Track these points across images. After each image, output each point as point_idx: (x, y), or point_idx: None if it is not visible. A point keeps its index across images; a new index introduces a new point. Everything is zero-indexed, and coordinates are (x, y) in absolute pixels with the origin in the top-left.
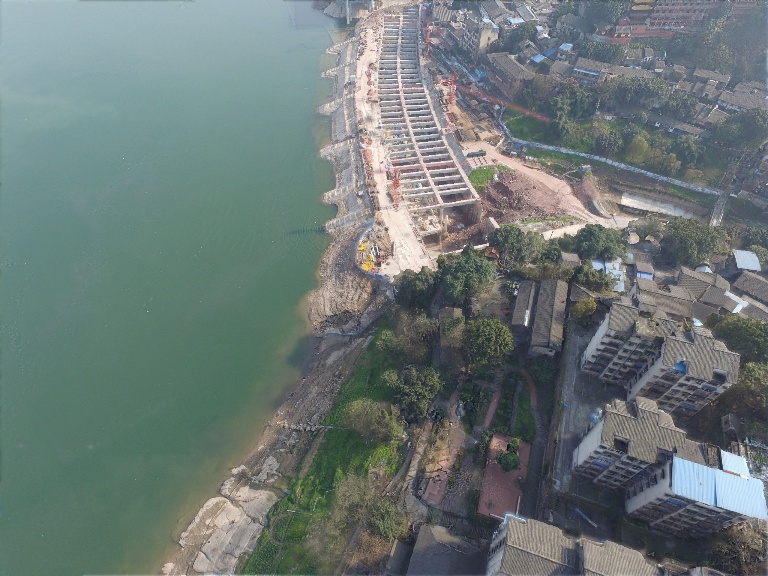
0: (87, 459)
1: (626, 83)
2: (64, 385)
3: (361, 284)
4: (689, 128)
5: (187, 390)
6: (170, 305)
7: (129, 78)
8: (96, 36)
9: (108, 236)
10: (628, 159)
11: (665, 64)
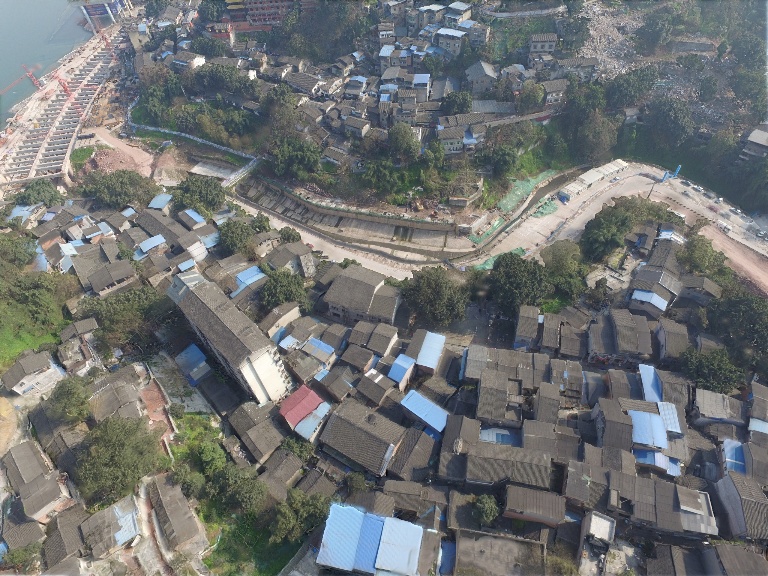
0: None
1: (202, 70)
2: None
3: None
4: (251, 105)
5: None
6: None
7: None
8: None
9: None
10: None
11: (266, 54)
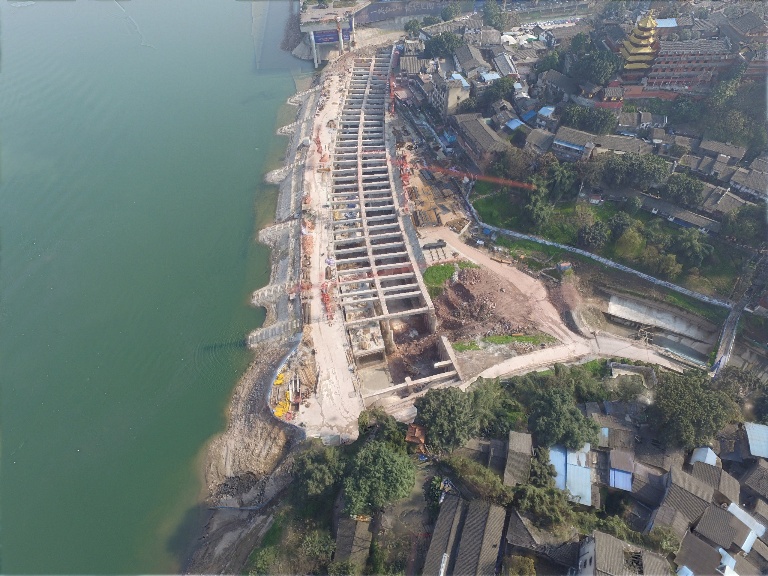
0: None
1: (615, 162)
2: None
3: (272, 434)
4: (693, 218)
5: None
6: (43, 453)
7: (67, 137)
8: (46, 84)
9: None
10: (618, 253)
11: (666, 131)
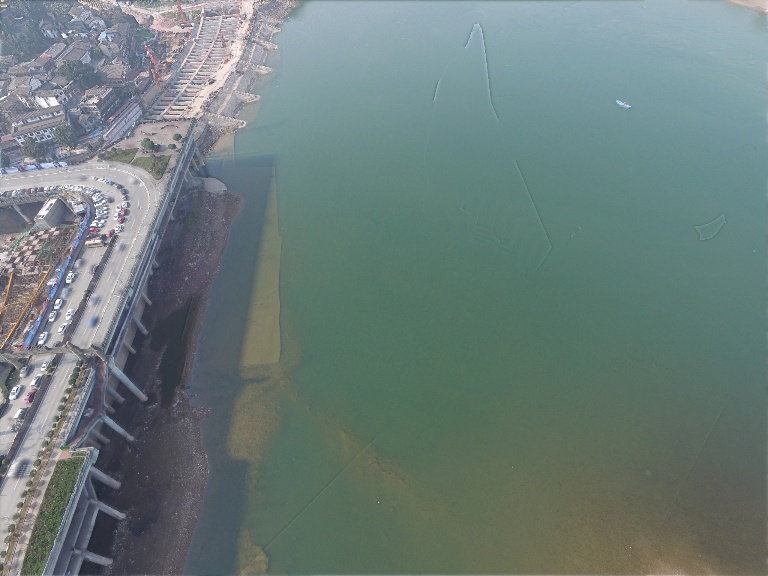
0: None
1: None
2: None
3: None
4: None
5: None
6: None
7: None
8: (542, 159)
9: None
10: None
11: None
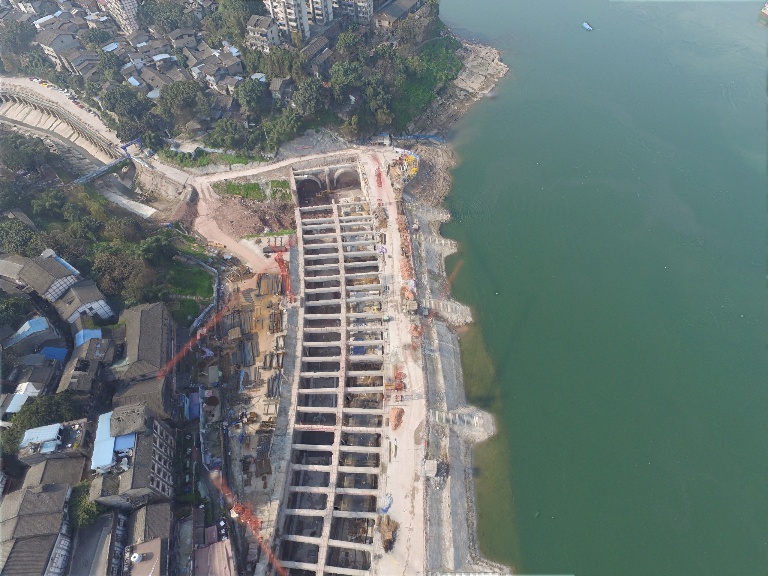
0: (556, 104)
1: None
2: (597, 128)
3: None
4: (22, 218)
5: (519, 124)
6: None
7: None
8: None
9: (660, 217)
10: (108, 235)
11: None
